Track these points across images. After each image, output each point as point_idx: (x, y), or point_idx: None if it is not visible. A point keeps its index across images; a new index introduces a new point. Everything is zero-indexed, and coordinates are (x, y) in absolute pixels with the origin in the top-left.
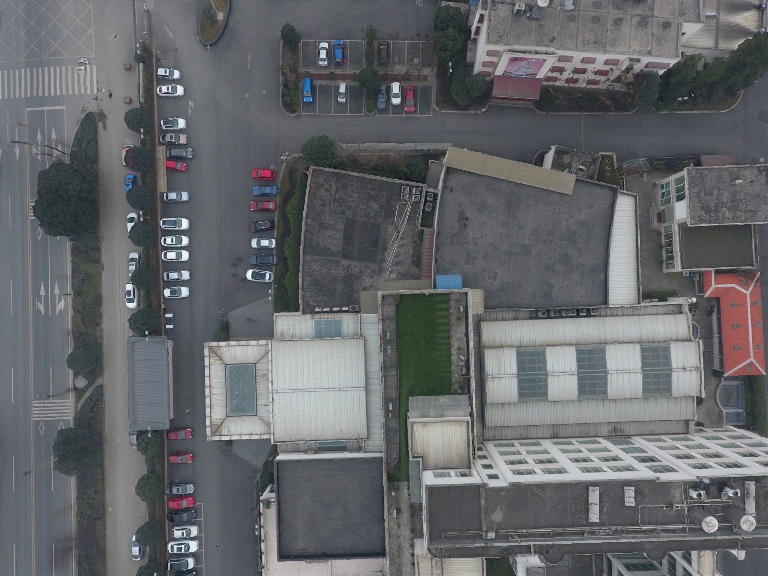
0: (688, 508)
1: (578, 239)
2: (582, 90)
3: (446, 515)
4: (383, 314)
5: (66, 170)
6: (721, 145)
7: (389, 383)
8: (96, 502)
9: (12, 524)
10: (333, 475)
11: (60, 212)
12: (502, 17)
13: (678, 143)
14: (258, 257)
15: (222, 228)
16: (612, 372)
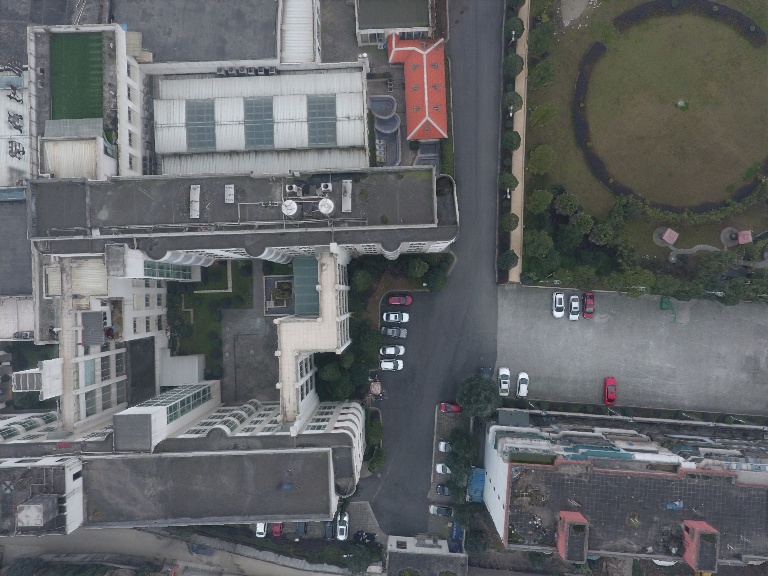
0: None
1: None
2: None
3: (54, 214)
4: (37, 52)
5: None
6: None
7: (42, 119)
8: None
9: None
10: (3, 219)
11: None
12: None
13: None
14: None
15: None
16: (278, 121)
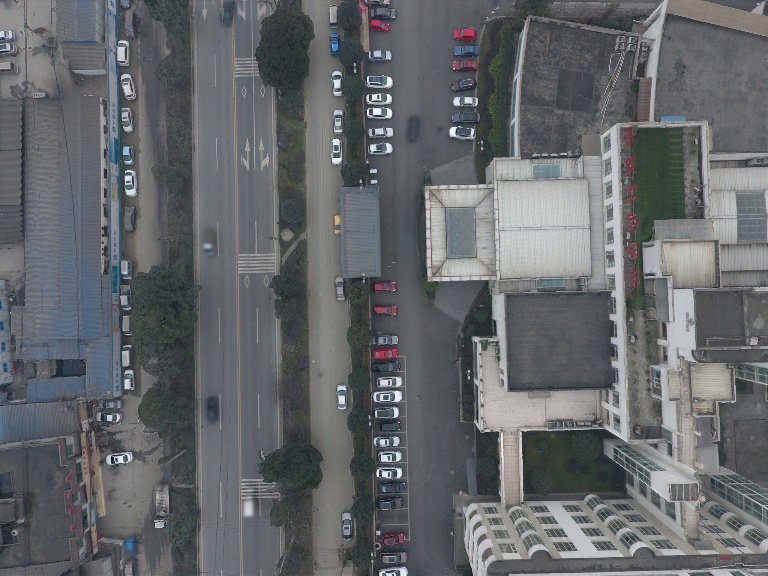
0: None
1: None
2: None
3: (708, 322)
4: None
5: (291, 15)
6: None
7: (624, 214)
8: (301, 353)
9: (218, 374)
10: (559, 311)
11: (286, 56)
12: None
13: None
14: (462, 114)
15: (423, 88)
16: None
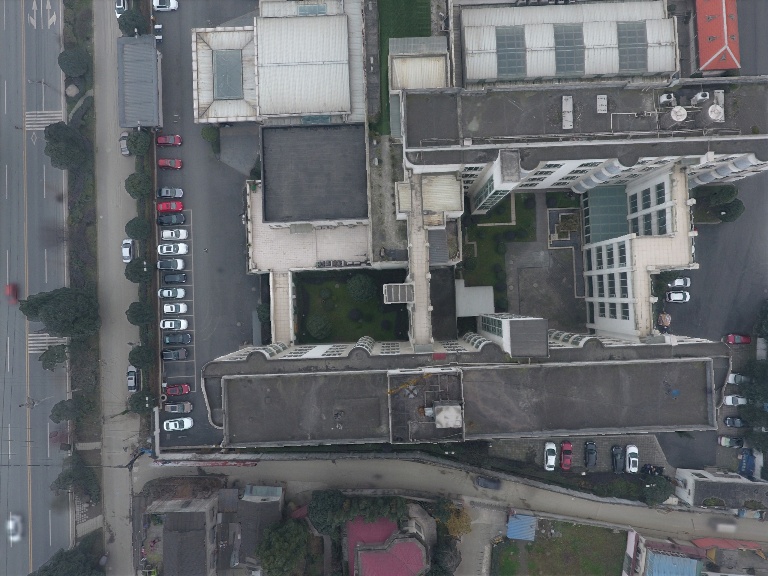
0: (659, 116)
1: None
2: None
3: (424, 125)
4: None
5: None
6: None
7: (371, 41)
8: (87, 208)
9: (5, 231)
10: (317, 145)
11: None
12: None
13: None
14: None
15: None
16: (589, 47)
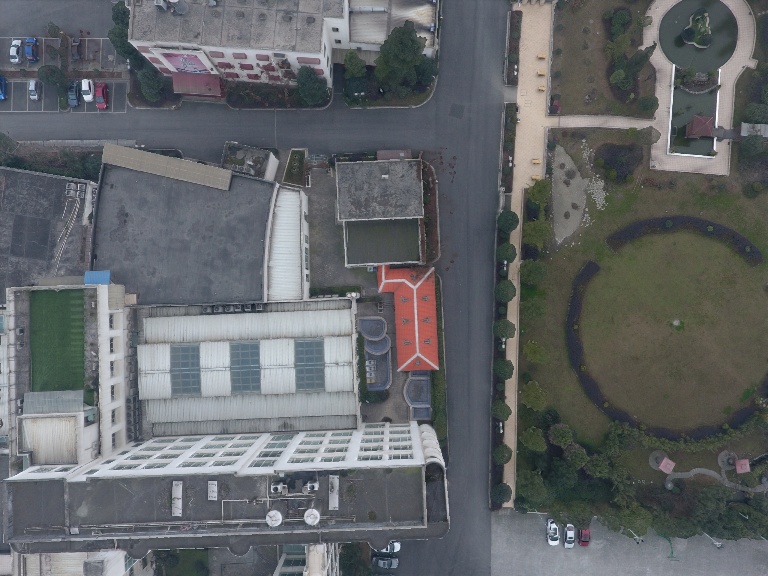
0: (272, 502)
1: (237, 235)
2: (272, 86)
3: (32, 510)
4: (17, 310)
5: None
6: (413, 140)
7: (22, 379)
8: None
9: None
10: None
11: None
12: (147, 13)
13: (370, 139)
14: None
15: None
16: (265, 367)
